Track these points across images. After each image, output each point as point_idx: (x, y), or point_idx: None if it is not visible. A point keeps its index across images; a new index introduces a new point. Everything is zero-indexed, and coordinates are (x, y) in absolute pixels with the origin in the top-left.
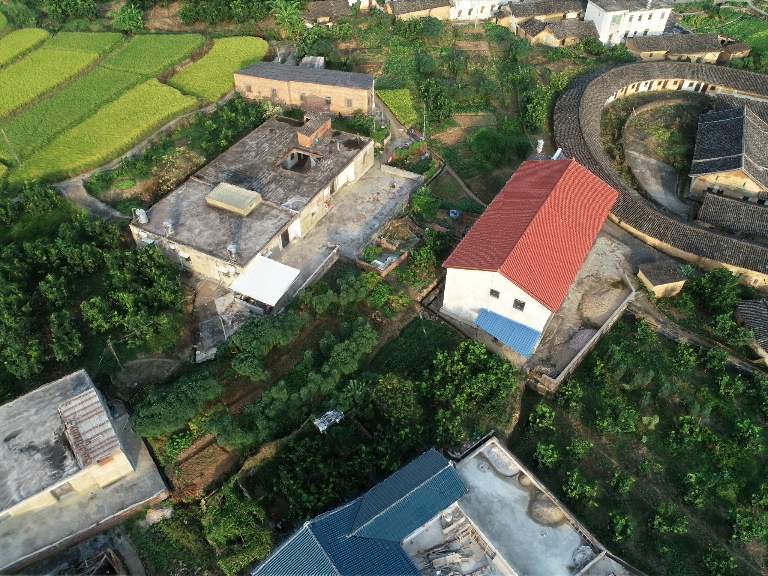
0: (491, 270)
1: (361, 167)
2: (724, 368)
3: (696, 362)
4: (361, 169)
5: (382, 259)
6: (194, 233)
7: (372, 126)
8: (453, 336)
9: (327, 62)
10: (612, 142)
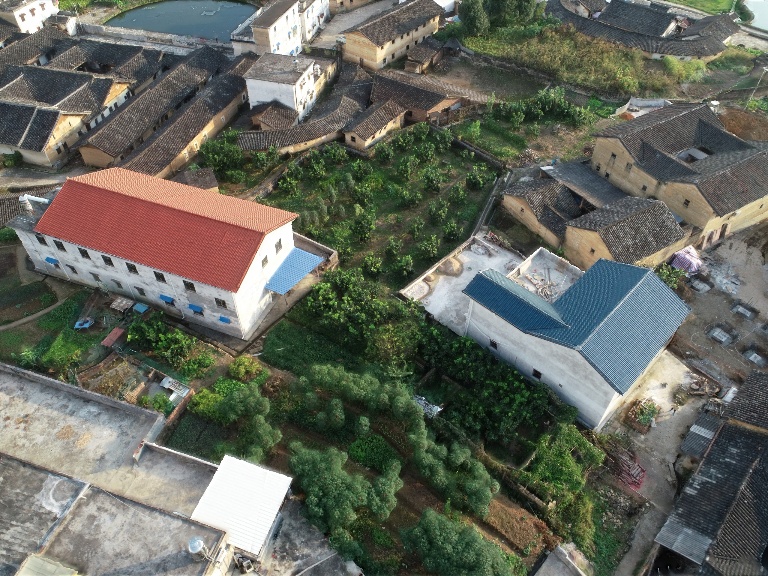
0: (262, 241)
1: None
2: None
3: None
4: None
5: None
6: None
7: None
8: None
9: None
10: None
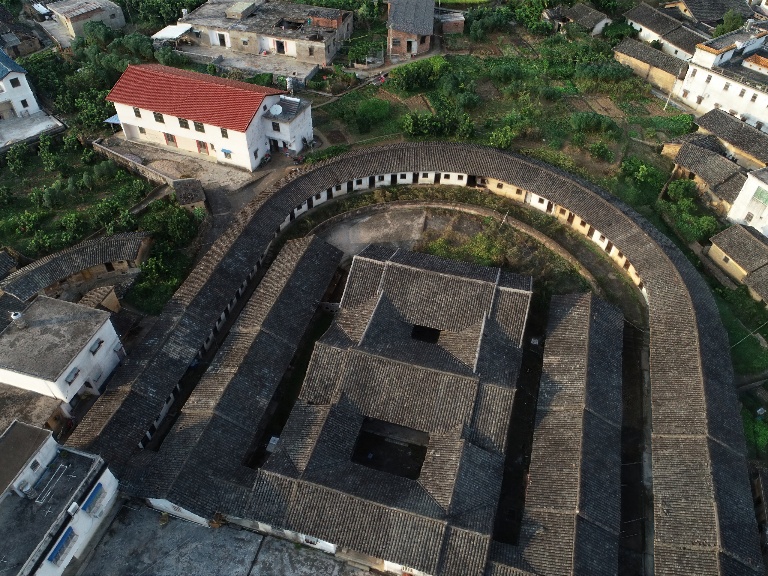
0: (133, 65)
1: (307, 54)
2: (92, 226)
3: None
4: (307, 56)
5: None
6: (211, 8)
7: None
8: None
9: None
10: None
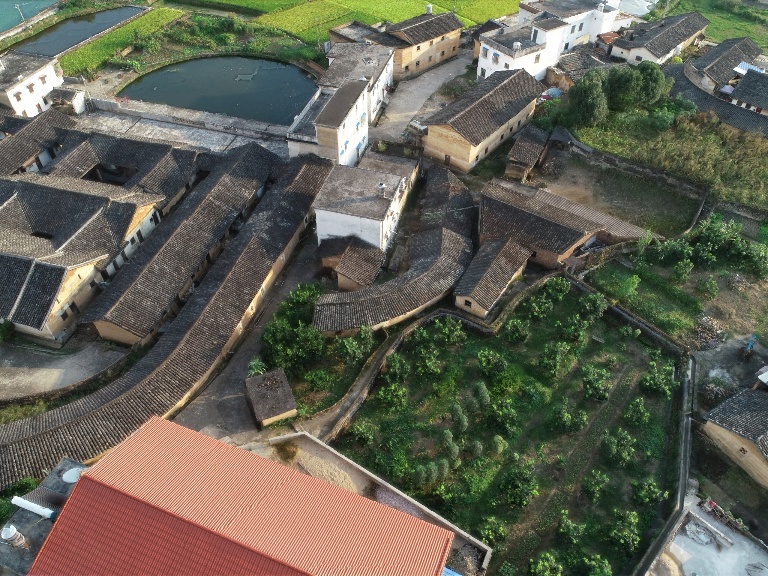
0: None
1: None
2: None
3: None
4: None
5: None
6: None
7: None
8: None
9: None
10: None
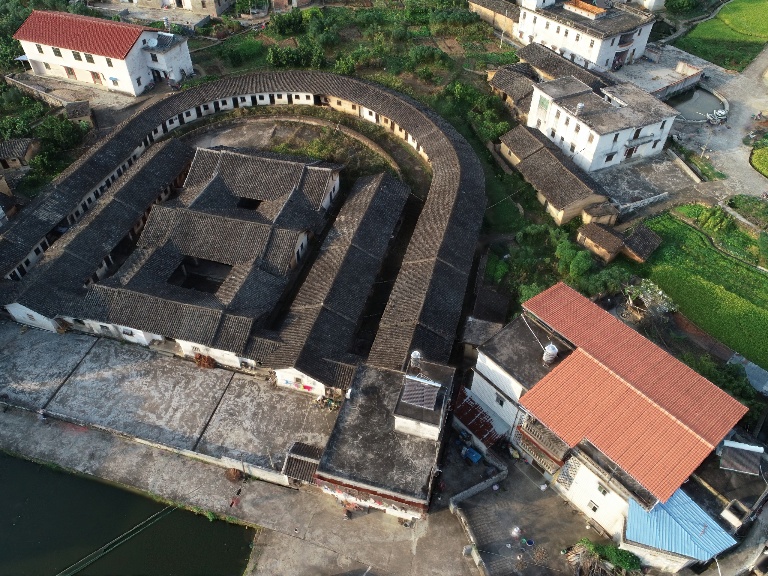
0: None
1: (200, 7)
2: None
3: None
4: (201, 9)
5: None
6: None
7: None
8: None
9: None
10: None
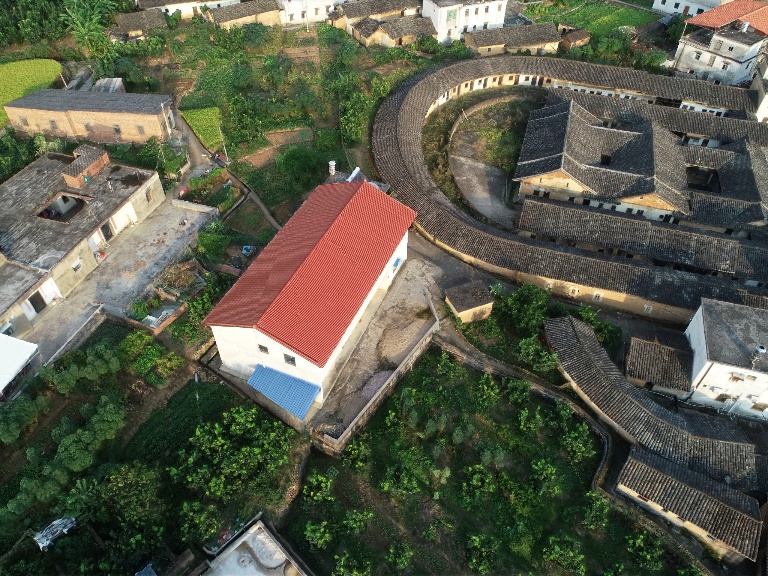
0: (247, 326)
1: (145, 205)
2: (528, 399)
3: (499, 395)
4: (146, 207)
5: (159, 313)
6: None
7: (158, 157)
8: (230, 399)
9: (129, 83)
10: (438, 149)
